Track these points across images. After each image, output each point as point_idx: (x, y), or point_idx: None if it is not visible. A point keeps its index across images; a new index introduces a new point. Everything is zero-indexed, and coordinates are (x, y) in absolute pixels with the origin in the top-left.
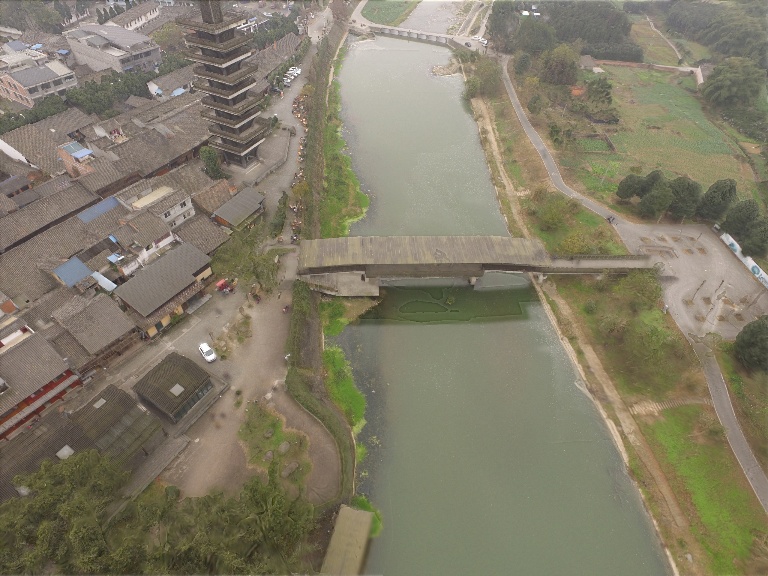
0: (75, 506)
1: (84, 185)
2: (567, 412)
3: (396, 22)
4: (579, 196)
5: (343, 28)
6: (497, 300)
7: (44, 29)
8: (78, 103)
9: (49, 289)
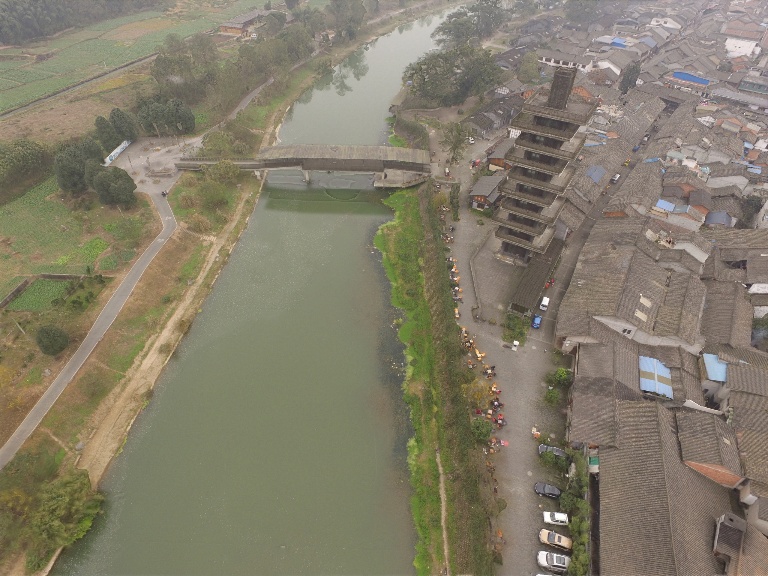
0: (468, 50)
1: None
2: None
3: None
4: (164, 216)
5: None
6: (298, 170)
7: None
8: None
9: None
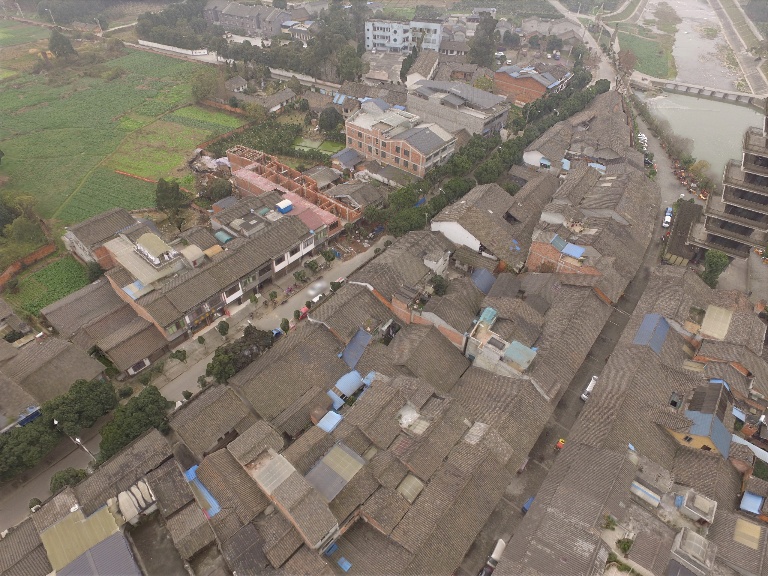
0: None
1: (595, 293)
2: None
3: (671, 76)
4: None
5: (624, 82)
6: None
7: (344, 78)
8: (454, 170)
9: (675, 452)
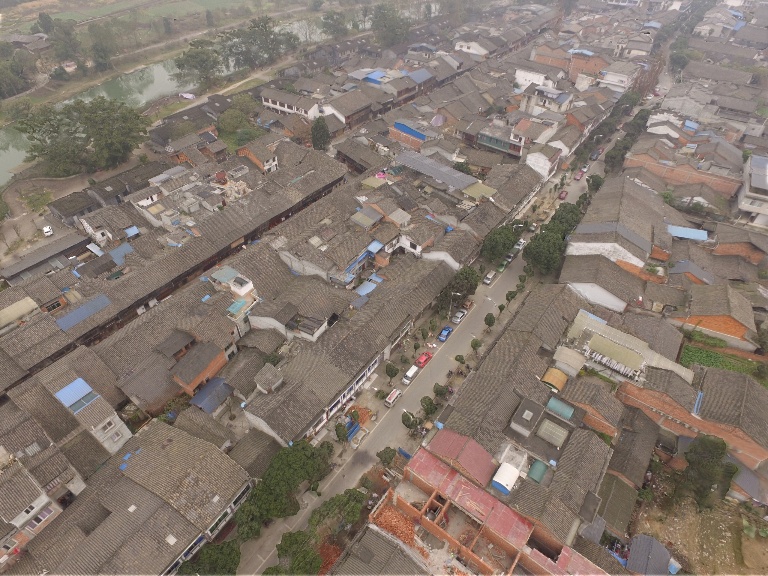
0: (80, 105)
1: None
2: None
3: None
4: None
5: None
6: None
7: None
8: None
9: None
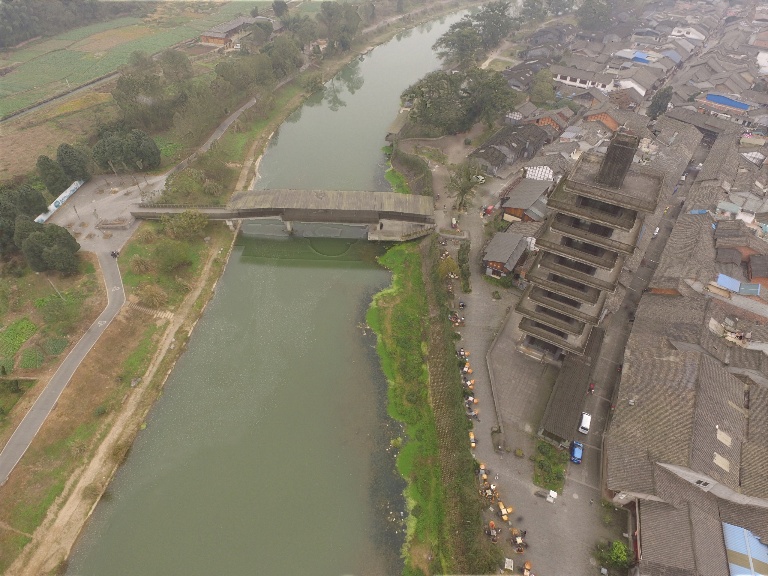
0: (477, 72)
1: None
2: (276, 169)
3: None
4: (111, 287)
5: None
6: None
7: None
8: None
9: None
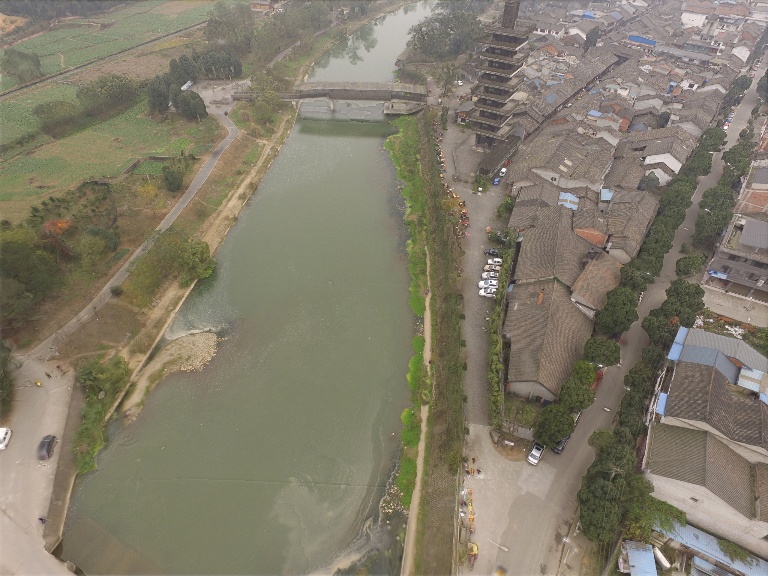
0: (459, 14)
1: None
2: None
3: None
4: (229, 126)
5: None
6: (324, 103)
7: None
8: None
9: None
